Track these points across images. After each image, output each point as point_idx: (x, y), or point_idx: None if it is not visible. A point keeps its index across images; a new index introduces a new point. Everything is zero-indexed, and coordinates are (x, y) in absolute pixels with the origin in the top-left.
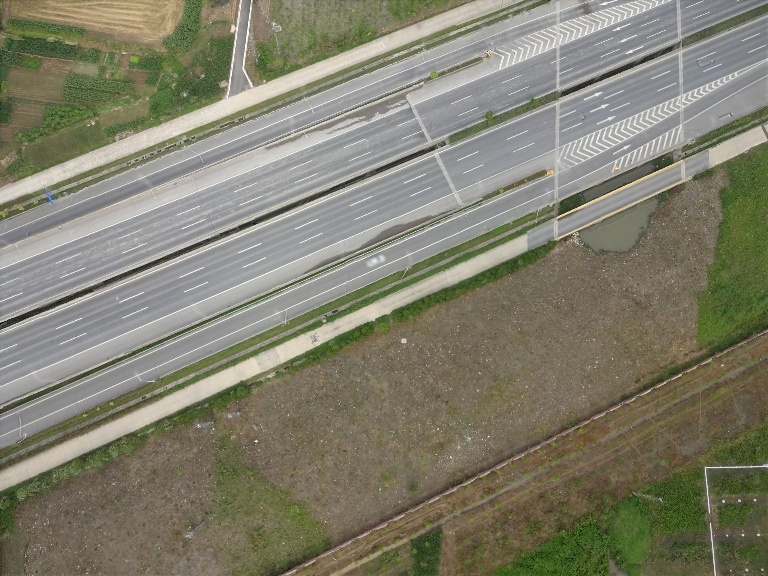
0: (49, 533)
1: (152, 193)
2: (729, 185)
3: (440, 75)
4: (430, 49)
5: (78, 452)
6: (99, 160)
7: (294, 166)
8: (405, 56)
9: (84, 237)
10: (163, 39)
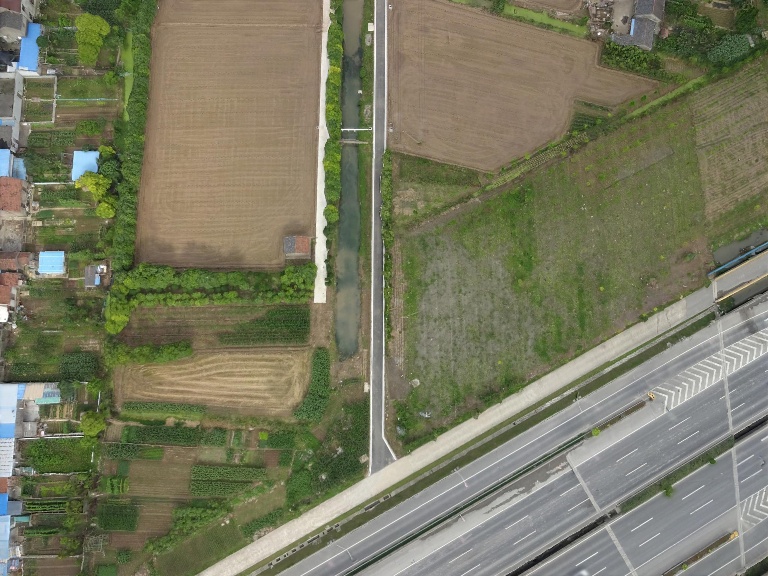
0: None
1: None
2: None
3: (602, 429)
4: (586, 396)
5: None
6: (238, 565)
7: (454, 558)
8: (559, 406)
9: None
10: (292, 408)
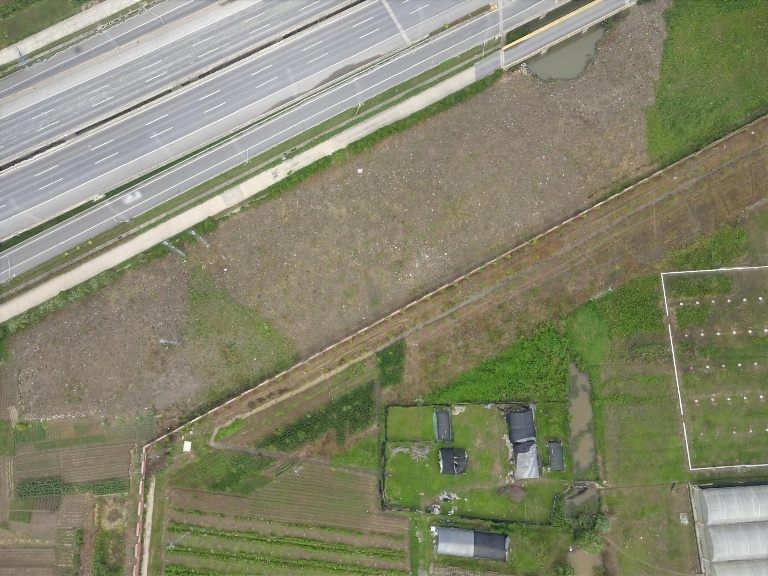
0: (39, 358)
1: (117, 51)
2: (673, 5)
3: None
4: None
5: (63, 288)
6: (68, 29)
7: (248, 19)
8: None
9: (57, 94)
10: None
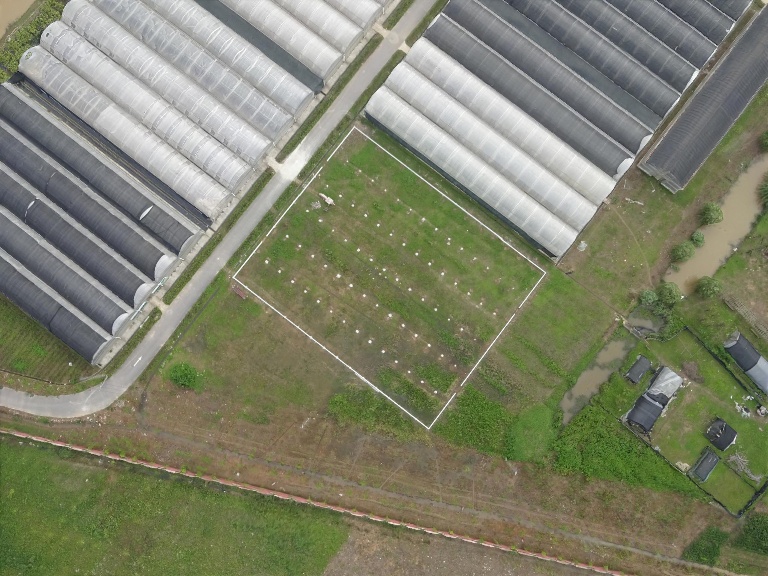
0: None
1: None
2: None
3: None
4: None
5: None
6: None
7: None
8: None
9: None
10: None
